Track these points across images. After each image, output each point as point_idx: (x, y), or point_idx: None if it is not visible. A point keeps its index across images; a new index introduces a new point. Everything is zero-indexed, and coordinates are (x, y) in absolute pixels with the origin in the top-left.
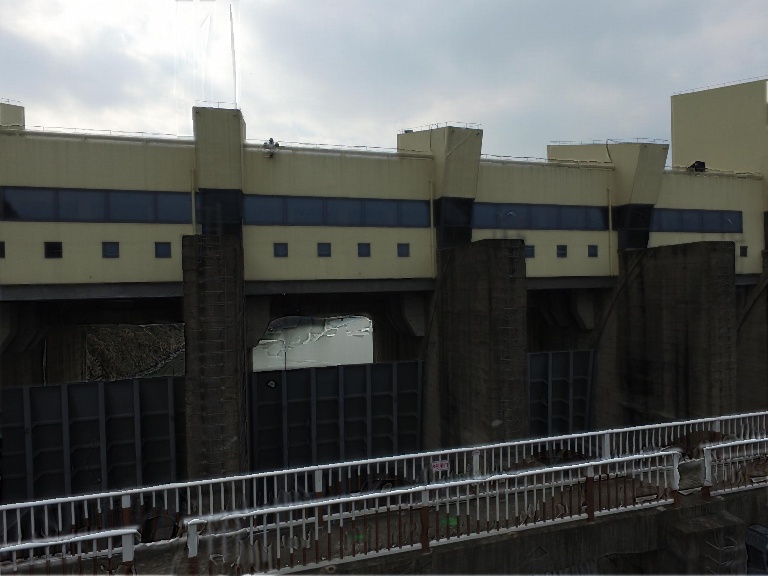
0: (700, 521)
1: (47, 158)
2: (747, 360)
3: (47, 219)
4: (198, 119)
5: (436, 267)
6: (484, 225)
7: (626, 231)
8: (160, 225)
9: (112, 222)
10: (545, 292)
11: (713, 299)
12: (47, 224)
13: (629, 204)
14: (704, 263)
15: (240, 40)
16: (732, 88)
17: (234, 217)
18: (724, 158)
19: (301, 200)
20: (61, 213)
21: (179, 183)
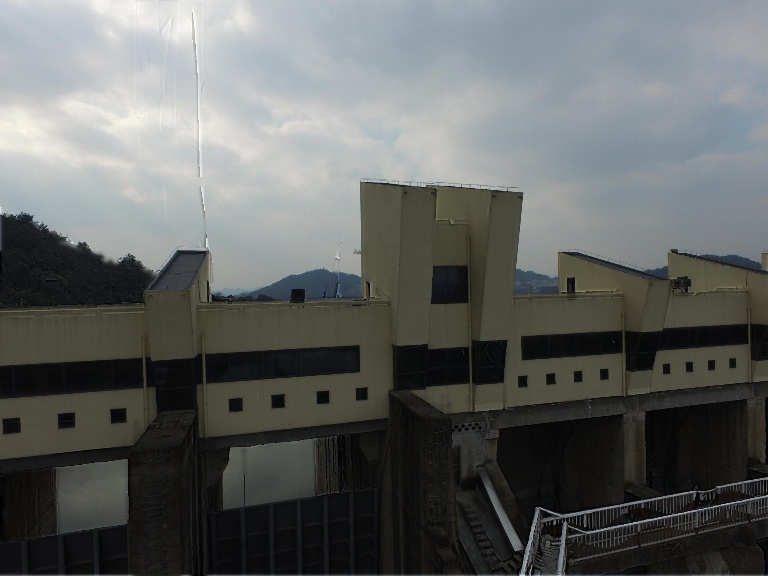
0: None
1: None
2: (385, 516)
3: None
4: None
5: None
6: None
7: (156, 392)
8: None
9: None
10: None
11: (135, 529)
12: None
13: (152, 361)
14: None
15: (203, 45)
16: (378, 188)
17: None
18: (378, 269)
19: None
20: None
21: None
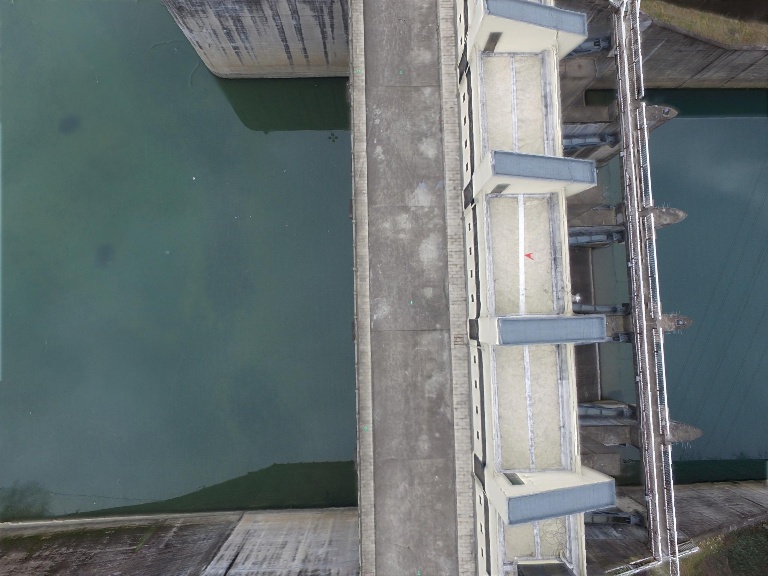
0: (646, 215)
1: None
2: None
3: None
4: None
5: None
6: None
7: None
8: None
9: None
10: None
11: None
12: None
13: None
14: None
15: None
16: None
17: None
18: None
19: None
20: None
21: None
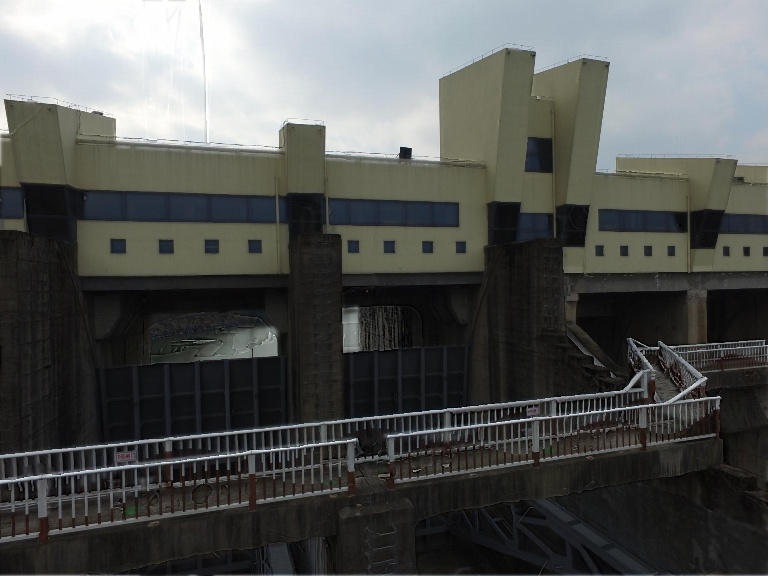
0: None
1: None
2: (477, 366)
3: None
4: None
5: None
6: (105, 216)
7: (290, 224)
8: None
9: None
10: (255, 292)
11: (306, 301)
12: None
13: (288, 193)
14: (299, 259)
15: (210, 35)
16: (469, 69)
17: None
18: (466, 146)
19: None
20: None
21: None
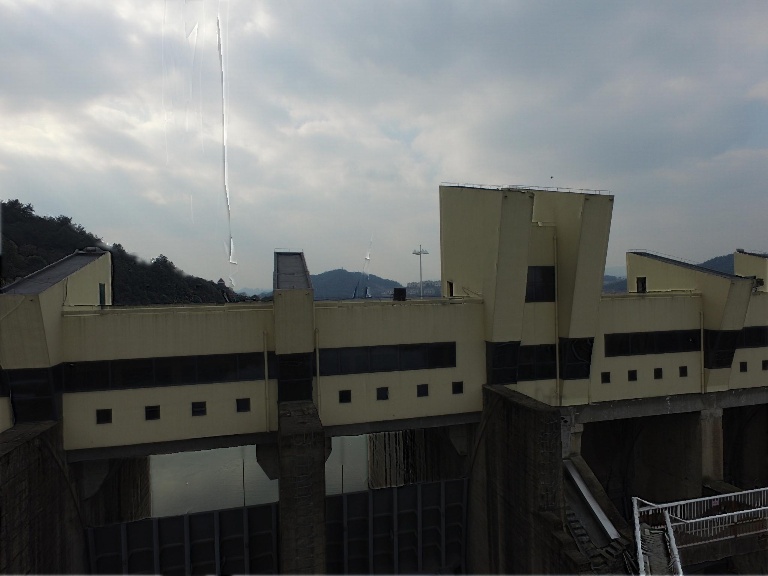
0: None
1: None
2: (476, 504)
3: None
4: None
5: None
6: (92, 386)
7: (278, 383)
8: None
9: None
10: None
11: (287, 505)
12: None
13: (276, 355)
14: None
15: (228, 49)
16: (467, 192)
17: None
18: (465, 269)
19: None
20: None
21: None
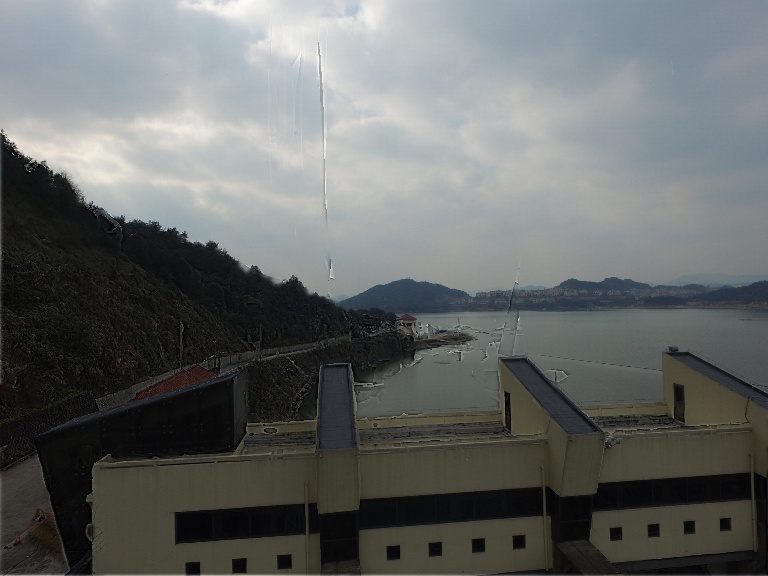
0: None
1: (429, 469)
2: None
3: (429, 522)
4: (570, 445)
5: (757, 539)
6: None
7: None
8: (516, 519)
9: (478, 520)
10: None
11: None
12: (430, 527)
13: None
14: None
15: (327, 74)
16: None
17: (584, 515)
18: None
19: (631, 483)
20: (439, 515)
21: (530, 479)
